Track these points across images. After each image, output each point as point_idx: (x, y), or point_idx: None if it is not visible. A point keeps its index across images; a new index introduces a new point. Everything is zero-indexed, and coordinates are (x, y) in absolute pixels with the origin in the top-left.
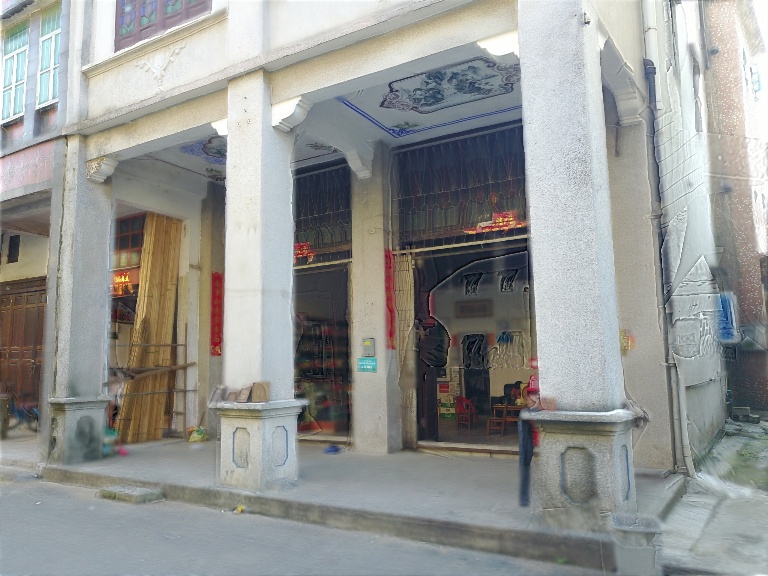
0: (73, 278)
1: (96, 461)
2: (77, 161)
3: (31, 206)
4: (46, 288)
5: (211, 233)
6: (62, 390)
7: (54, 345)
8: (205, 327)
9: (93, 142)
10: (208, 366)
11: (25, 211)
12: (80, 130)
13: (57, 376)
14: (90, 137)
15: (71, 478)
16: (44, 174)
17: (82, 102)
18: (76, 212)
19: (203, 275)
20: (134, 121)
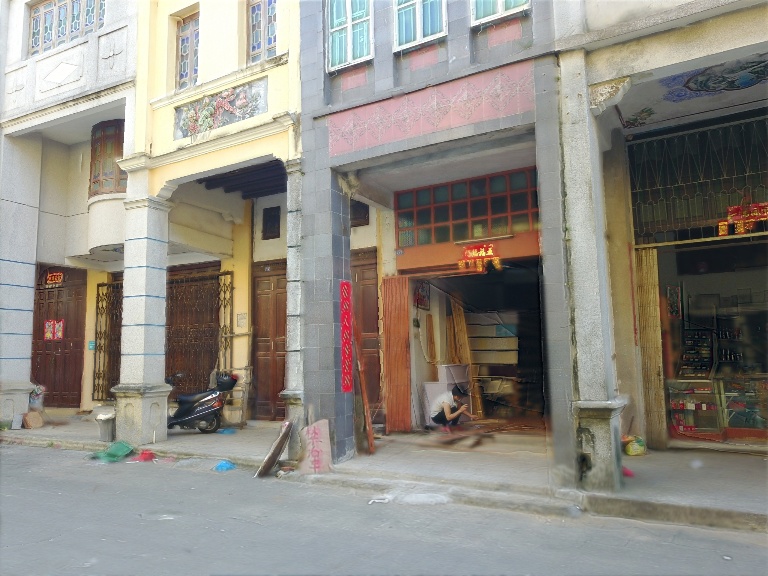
0: (595, 240)
1: (624, 486)
2: (584, 84)
3: (433, 156)
4: (541, 254)
5: (624, 193)
6: (597, 391)
7: (569, 330)
8: (624, 310)
9: (603, 59)
10: (634, 359)
11: (420, 163)
12: (593, 42)
13: (582, 372)
14: (595, 53)
15: (657, 513)
16: (516, 105)
17: (581, 7)
18: (590, 152)
19: (615, 245)
20: (697, 24)
